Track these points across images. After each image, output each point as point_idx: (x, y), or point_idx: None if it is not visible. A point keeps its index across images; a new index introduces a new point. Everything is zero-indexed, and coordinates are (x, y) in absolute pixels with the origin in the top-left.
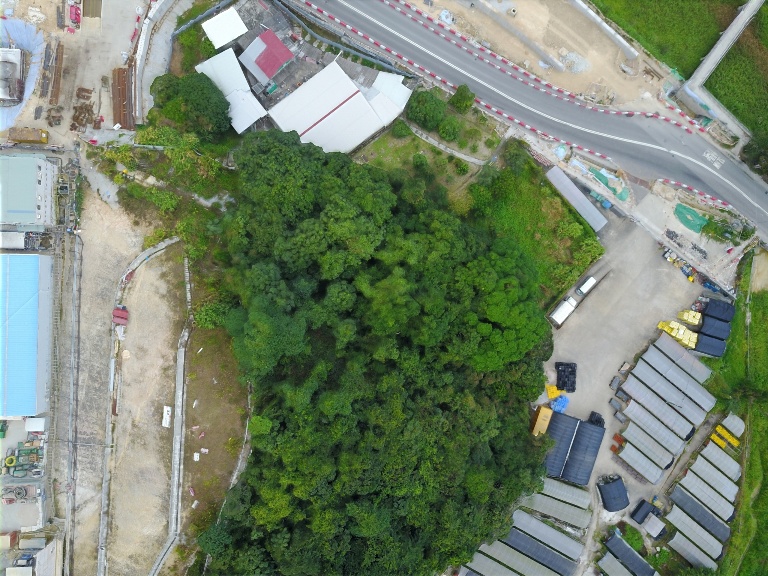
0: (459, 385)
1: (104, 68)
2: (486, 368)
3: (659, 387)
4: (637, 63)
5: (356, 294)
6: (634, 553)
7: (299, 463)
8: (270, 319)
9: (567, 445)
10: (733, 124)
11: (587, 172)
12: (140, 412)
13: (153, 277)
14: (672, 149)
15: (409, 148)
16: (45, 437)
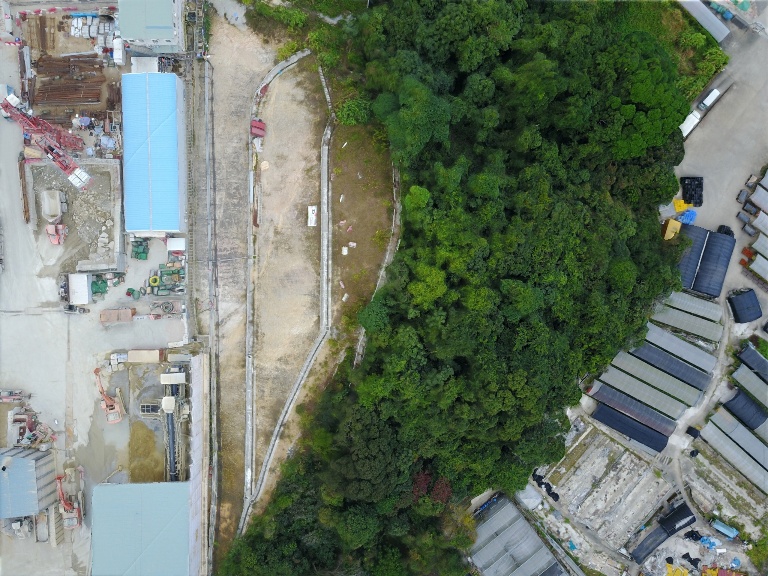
0: (595, 184)
1: None
2: (629, 154)
3: None
4: None
5: (495, 86)
6: None
7: (455, 238)
8: None
9: (698, 256)
10: None
11: None
12: (282, 218)
13: (288, 87)
14: None
15: None
16: (186, 257)
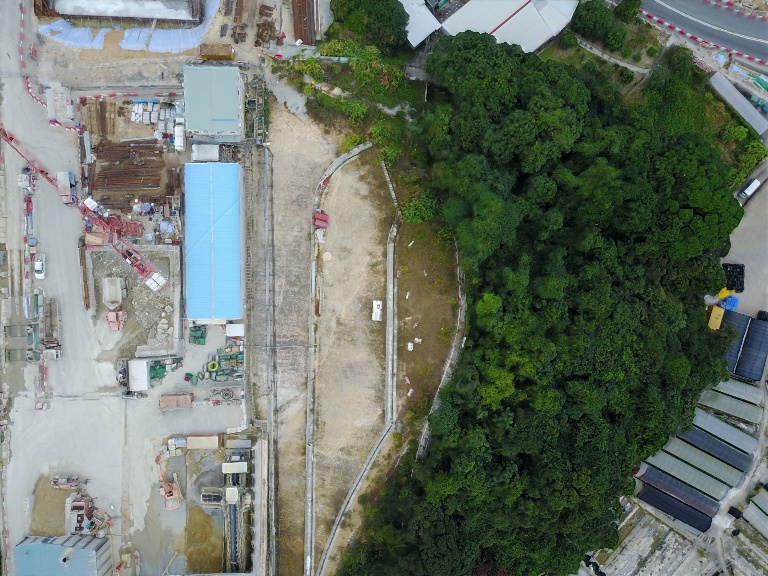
0: (648, 278)
1: None
2: (685, 255)
3: None
4: None
5: (557, 186)
6: None
7: (524, 342)
8: (501, 199)
9: (740, 342)
10: None
11: (748, 77)
12: (345, 310)
13: (352, 180)
14: None
15: (574, 59)
16: (244, 342)
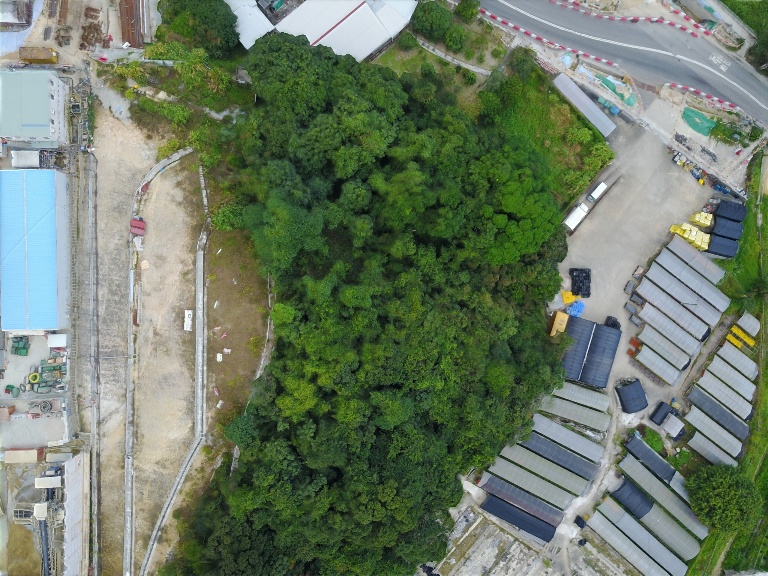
0: (476, 284)
1: None
2: (503, 261)
3: (673, 289)
4: None
5: (371, 192)
6: (654, 454)
7: (322, 352)
8: (289, 206)
9: (584, 348)
10: (738, 26)
11: (594, 78)
12: (161, 320)
13: (169, 186)
14: (678, 53)
15: (416, 61)
16: (67, 353)
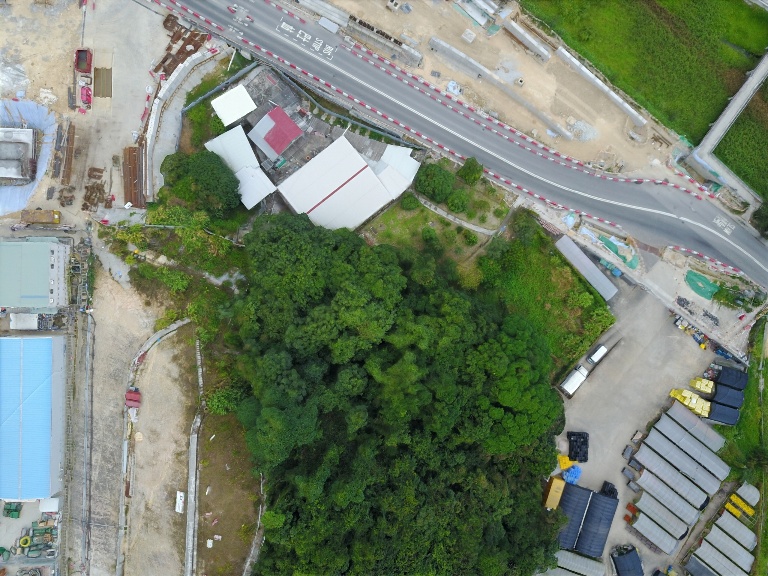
0: (471, 464)
1: (115, 147)
2: (498, 451)
3: (672, 456)
4: (645, 130)
5: (367, 378)
6: None
7: (312, 555)
8: (282, 415)
9: (580, 517)
10: (743, 190)
11: (597, 240)
12: (153, 495)
13: (165, 360)
14: (682, 216)
15: (418, 219)
16: (59, 517)
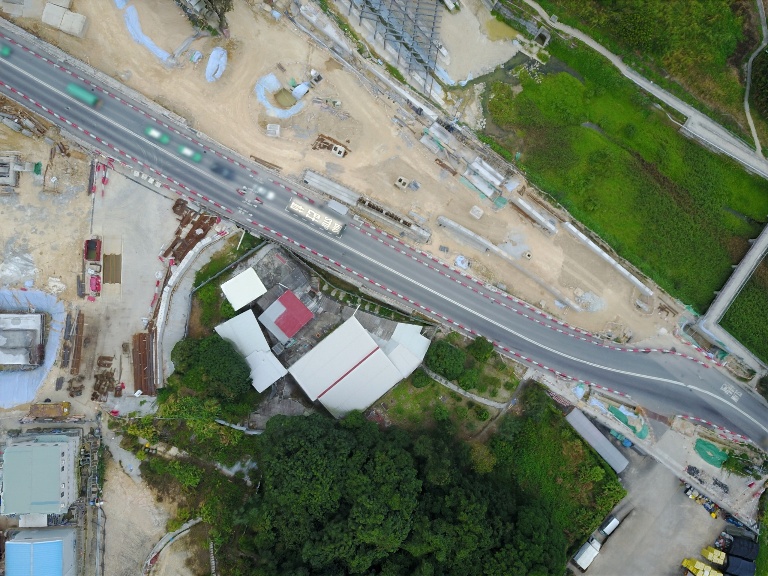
0: None
1: (124, 334)
2: None
3: None
4: (652, 300)
5: None
6: None
7: None
8: None
9: None
10: (749, 357)
11: (606, 412)
12: None
13: (178, 564)
14: (689, 384)
15: (429, 394)
16: None
